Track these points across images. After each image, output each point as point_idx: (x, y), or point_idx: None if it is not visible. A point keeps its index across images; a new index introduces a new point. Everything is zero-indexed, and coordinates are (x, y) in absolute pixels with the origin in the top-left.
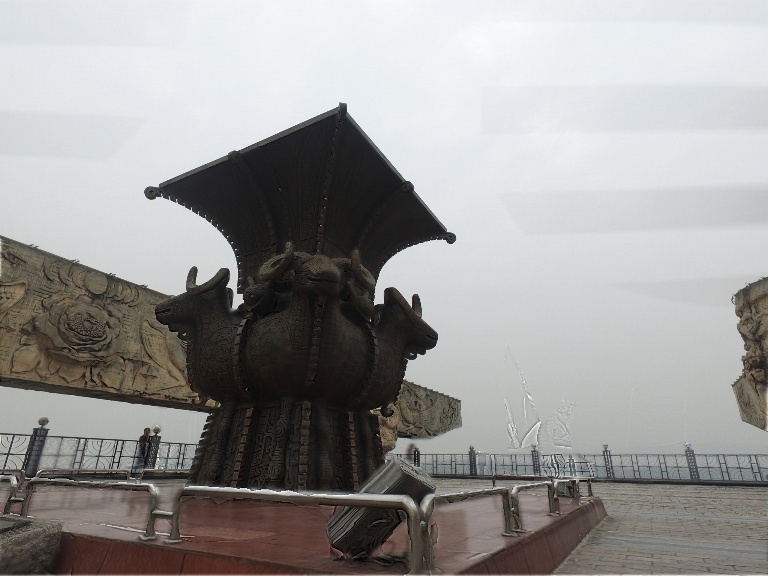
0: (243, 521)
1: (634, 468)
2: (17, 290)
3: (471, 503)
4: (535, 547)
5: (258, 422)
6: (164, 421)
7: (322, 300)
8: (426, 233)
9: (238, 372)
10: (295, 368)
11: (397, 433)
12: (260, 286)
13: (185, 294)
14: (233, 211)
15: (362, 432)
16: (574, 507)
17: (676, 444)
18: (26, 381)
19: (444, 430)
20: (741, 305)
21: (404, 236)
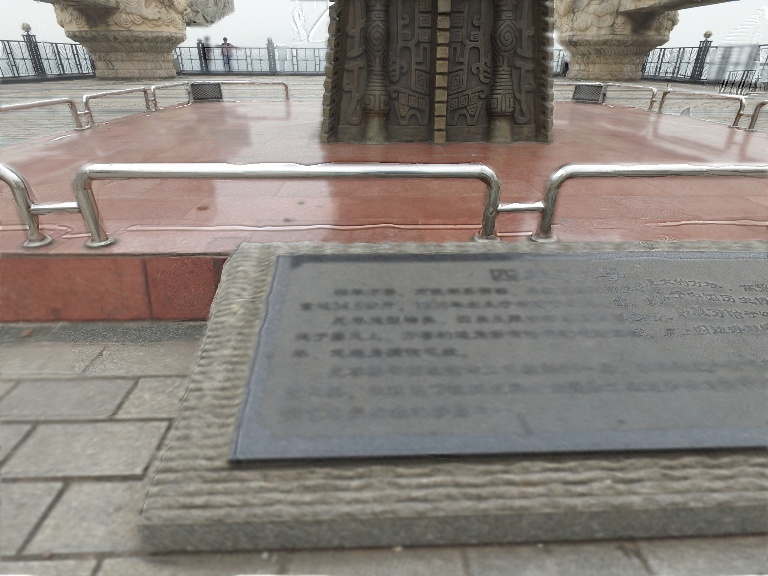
0: (705, 181)
1: None
2: None
3: (605, 120)
4: None
5: None
6: None
7: None
8: None
9: None
10: None
11: None
12: None
13: None
14: None
15: None
16: None
17: None
18: None
19: (219, 16)
20: None
21: None
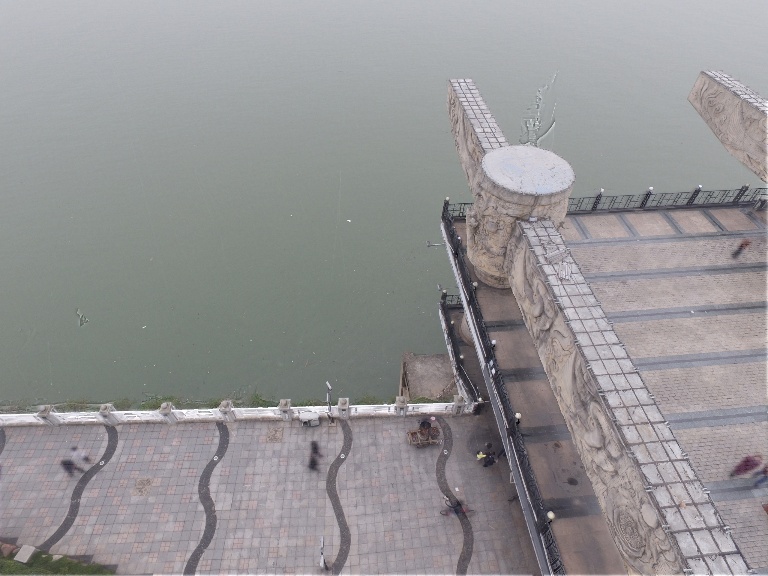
0: None
1: (660, 201)
2: None
3: None
4: None
5: None
6: (170, 226)
7: None
8: None
9: None
10: None
11: None
12: None
13: None
14: None
15: None
16: None
17: (693, 185)
18: None
19: None
20: None
21: None
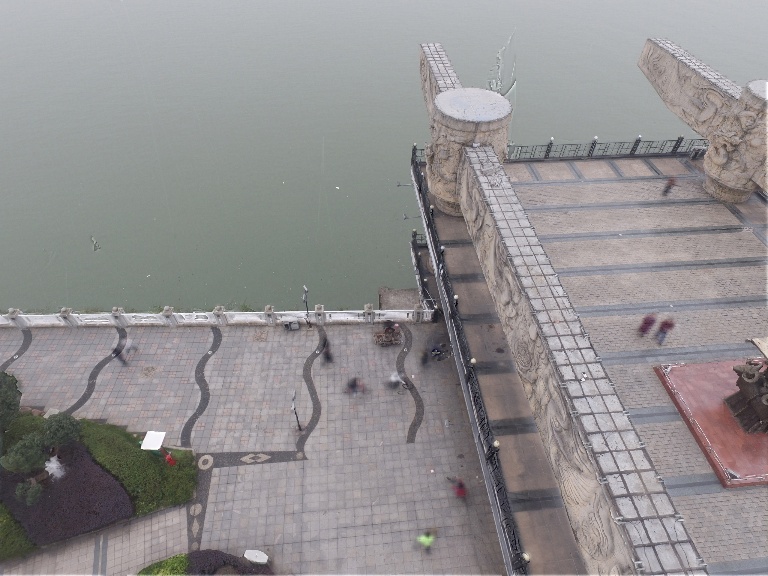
0: None
1: (605, 150)
2: None
3: None
4: None
5: None
6: (172, 157)
7: None
8: None
9: None
10: None
11: None
12: None
13: None
14: None
15: None
16: None
17: None
18: None
19: None
20: (757, 108)
21: None
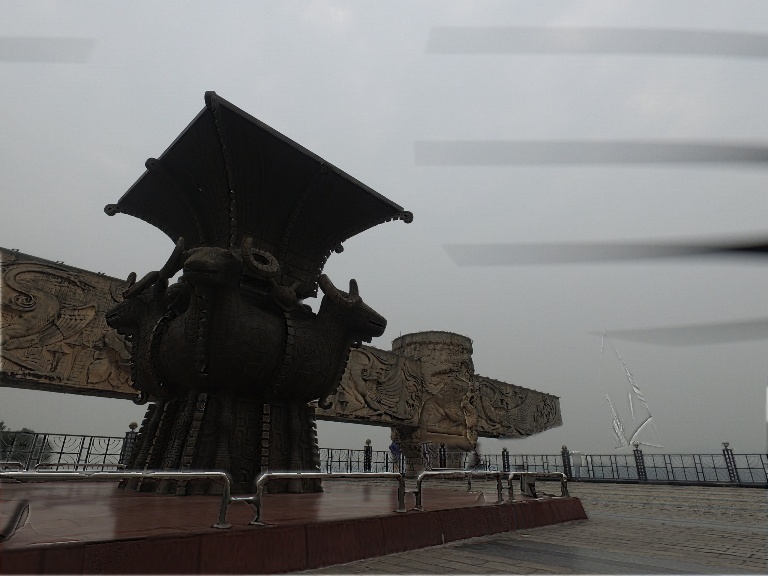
0: None
1: (765, 470)
2: (89, 312)
3: (378, 499)
4: (250, 541)
5: (174, 416)
6: None
7: (197, 291)
8: (378, 215)
9: (150, 368)
10: (188, 361)
11: (481, 433)
12: (177, 284)
13: (128, 299)
14: (174, 217)
15: (288, 425)
16: (473, 505)
17: None
18: (101, 390)
19: (539, 429)
20: None
21: (351, 221)
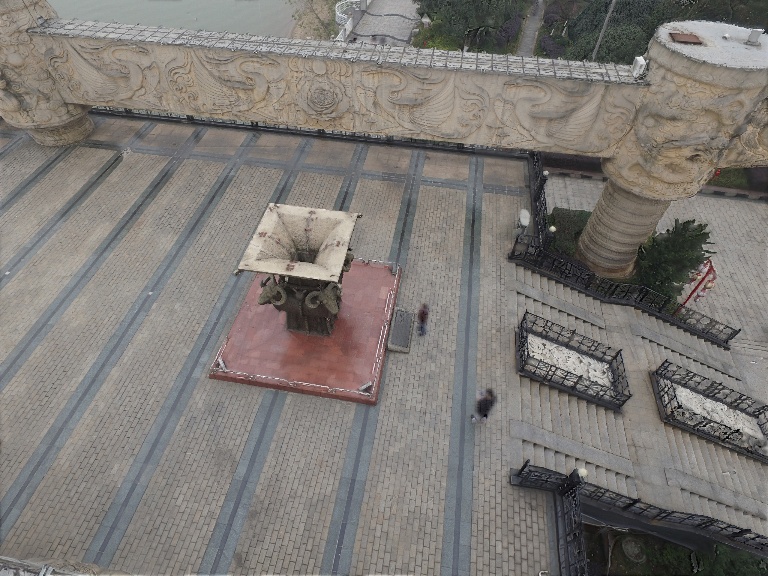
0: None
1: None
2: None
3: None
4: None
5: None
6: None
7: None
8: None
9: None
10: None
11: None
12: None
13: None
14: None
15: None
16: None
17: None
18: None
19: None
20: None
21: None
